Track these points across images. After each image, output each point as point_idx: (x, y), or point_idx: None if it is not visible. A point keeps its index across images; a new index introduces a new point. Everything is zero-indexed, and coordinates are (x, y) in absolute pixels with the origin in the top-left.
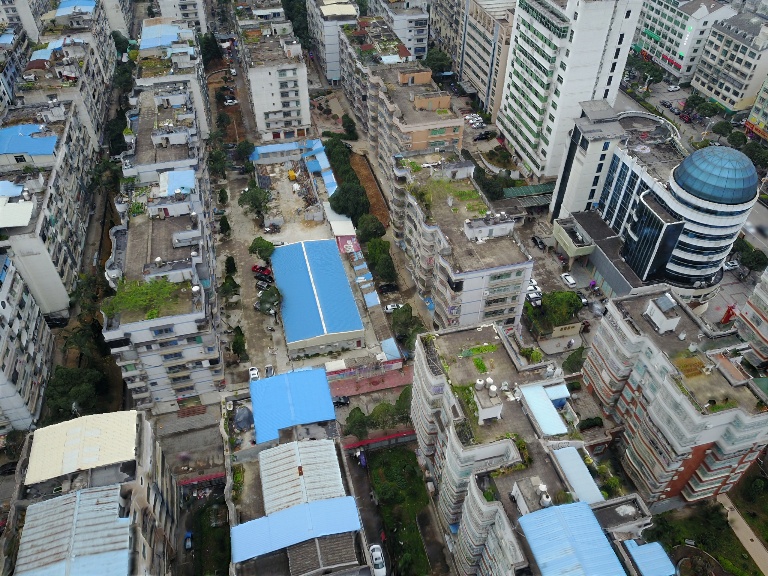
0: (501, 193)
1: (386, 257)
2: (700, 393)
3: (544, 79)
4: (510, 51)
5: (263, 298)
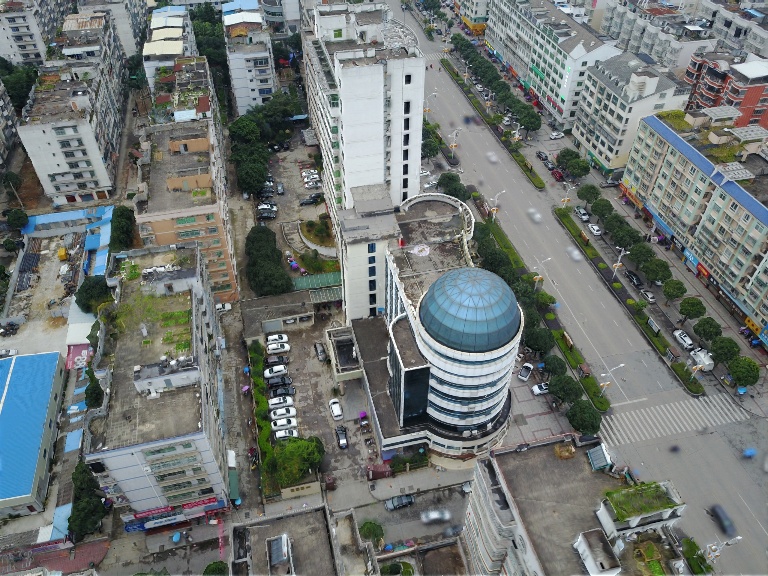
0: (286, 286)
1: (92, 387)
2: None
3: (331, 151)
4: None
5: None
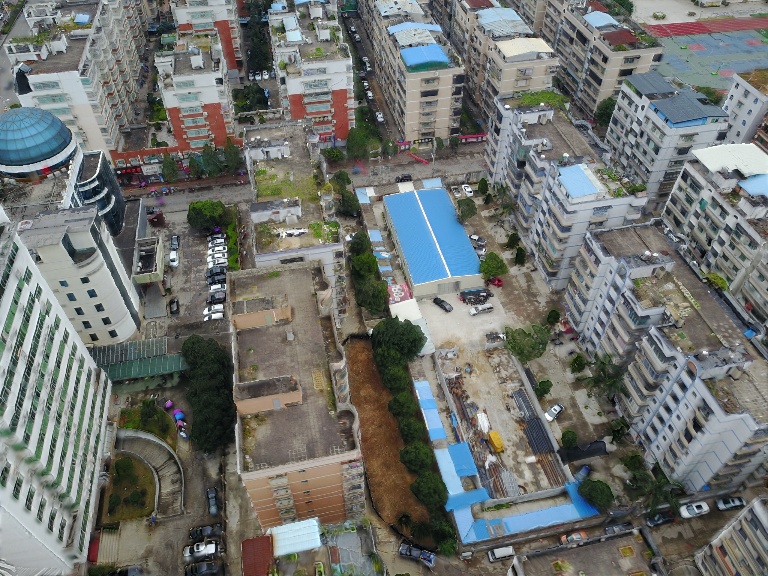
0: None
1: (359, 232)
2: None
3: None
4: (3, 499)
5: (472, 200)
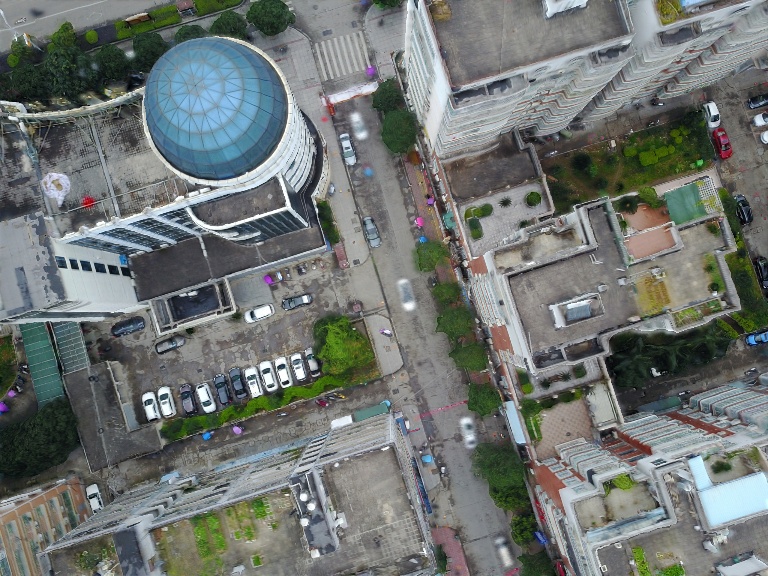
0: (65, 409)
1: None
2: (693, 293)
3: None
4: None
5: None
